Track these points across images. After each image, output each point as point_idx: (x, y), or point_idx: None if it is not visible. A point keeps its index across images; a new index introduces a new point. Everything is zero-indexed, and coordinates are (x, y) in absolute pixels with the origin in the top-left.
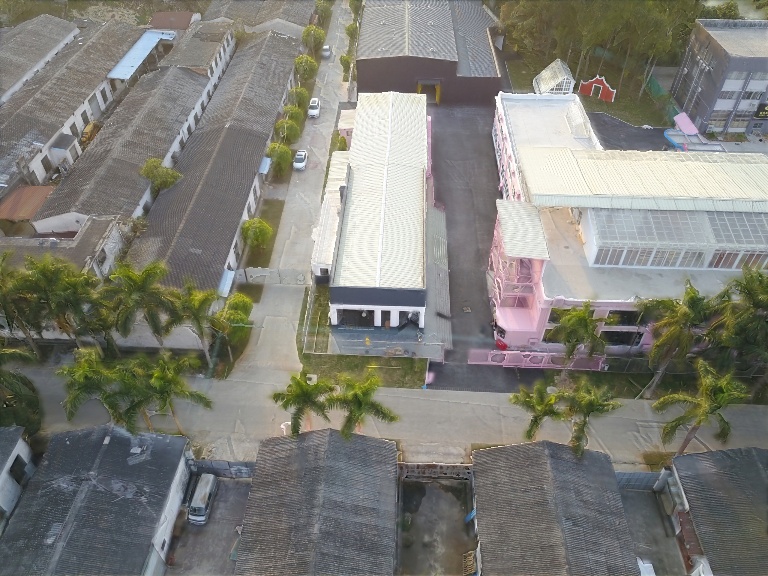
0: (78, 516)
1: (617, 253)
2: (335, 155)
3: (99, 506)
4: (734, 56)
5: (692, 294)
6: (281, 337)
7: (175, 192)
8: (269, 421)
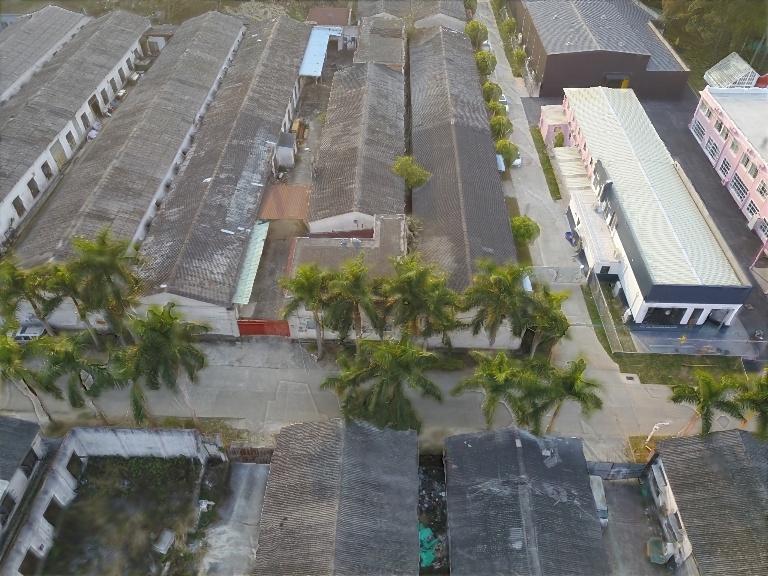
0: (534, 521)
1: None
2: (558, 151)
3: (545, 510)
4: None
5: None
6: (582, 336)
7: (432, 190)
8: (613, 421)
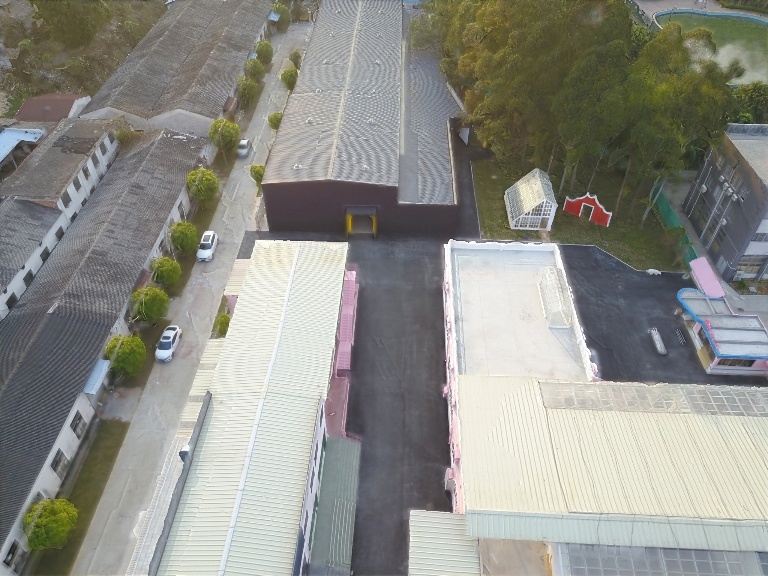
0: None
1: None
2: (209, 347)
3: None
4: None
5: None
6: None
7: None
8: None
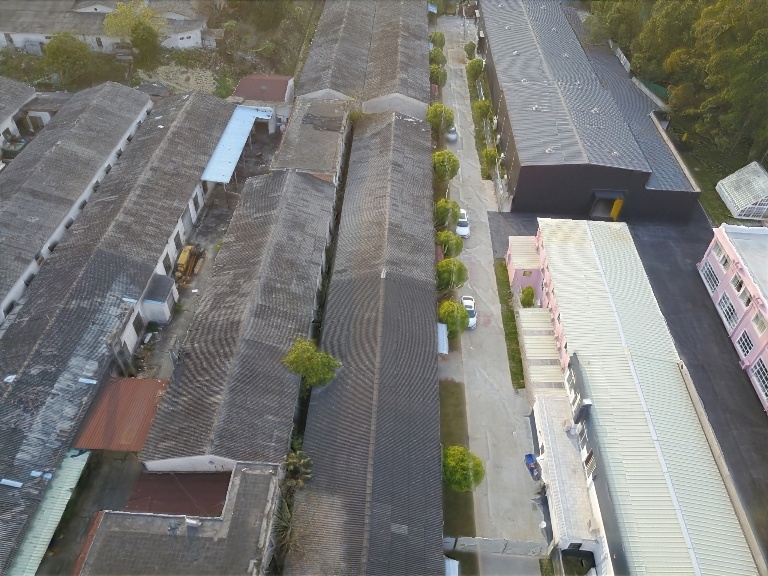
0: None
1: None
2: (525, 315)
3: None
4: None
5: None
6: None
7: (338, 397)
8: None
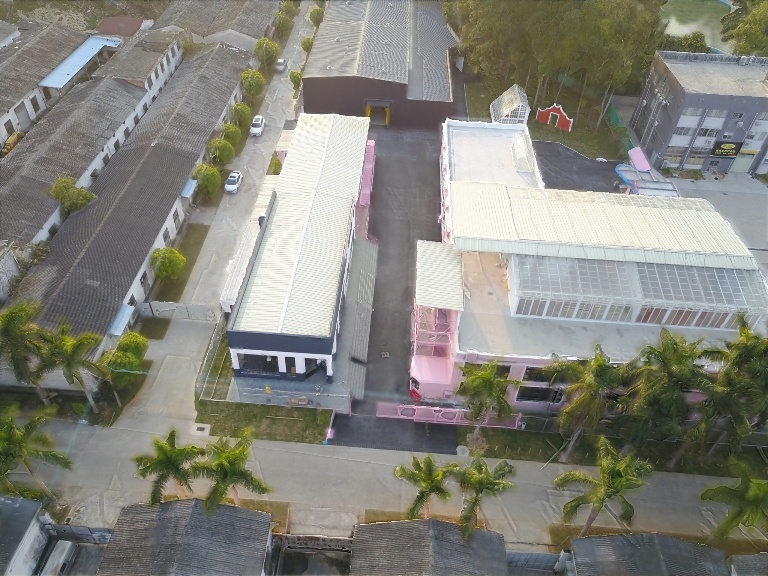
0: None
1: (540, 304)
2: (267, 179)
3: None
4: (689, 92)
5: (601, 361)
6: (179, 380)
7: (85, 215)
8: None
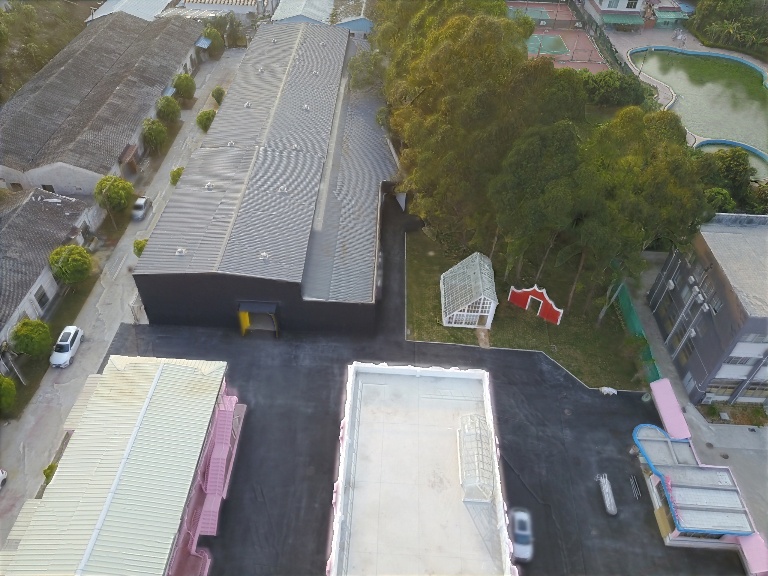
0: None
1: None
2: (25, 513)
3: None
4: (754, 316)
5: None
6: None
7: None
8: None
